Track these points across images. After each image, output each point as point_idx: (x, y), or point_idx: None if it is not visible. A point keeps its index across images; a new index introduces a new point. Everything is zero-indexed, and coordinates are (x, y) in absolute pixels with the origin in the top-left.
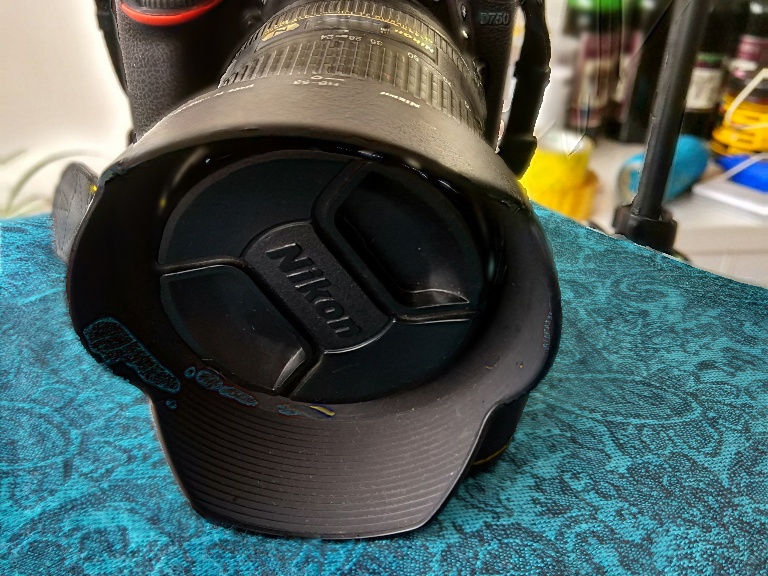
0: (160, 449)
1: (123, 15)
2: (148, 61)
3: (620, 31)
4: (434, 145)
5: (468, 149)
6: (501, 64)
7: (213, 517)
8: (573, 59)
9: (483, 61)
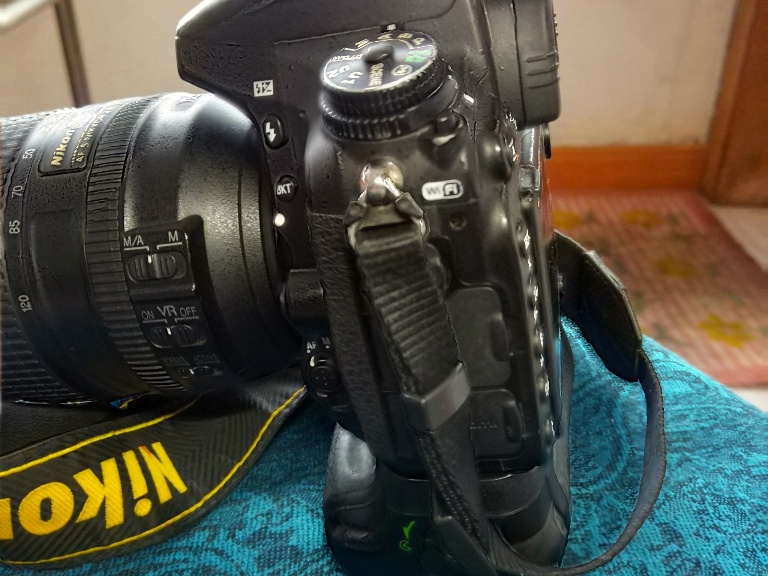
0: None
1: None
2: None
3: None
4: None
5: None
6: None
7: None
8: None
9: None
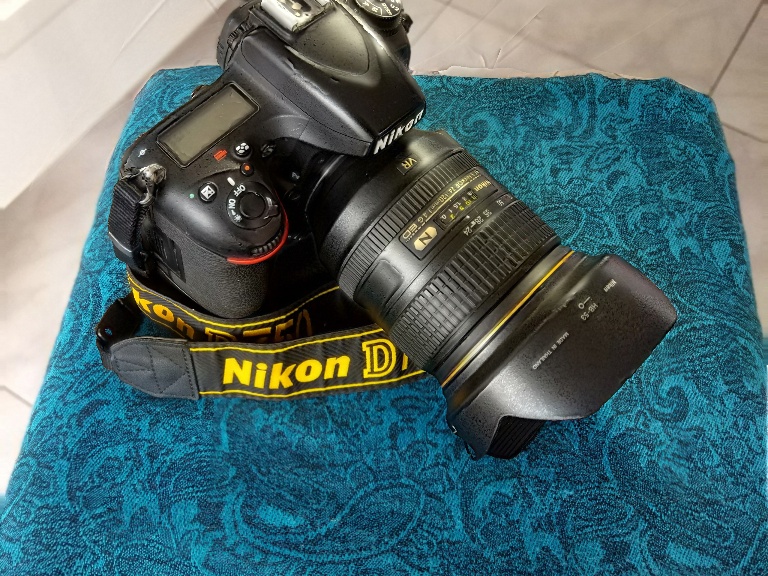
0: (446, 450)
1: None
2: (249, 272)
3: None
4: (656, 308)
5: (641, 285)
6: None
7: (515, 454)
8: None
9: None
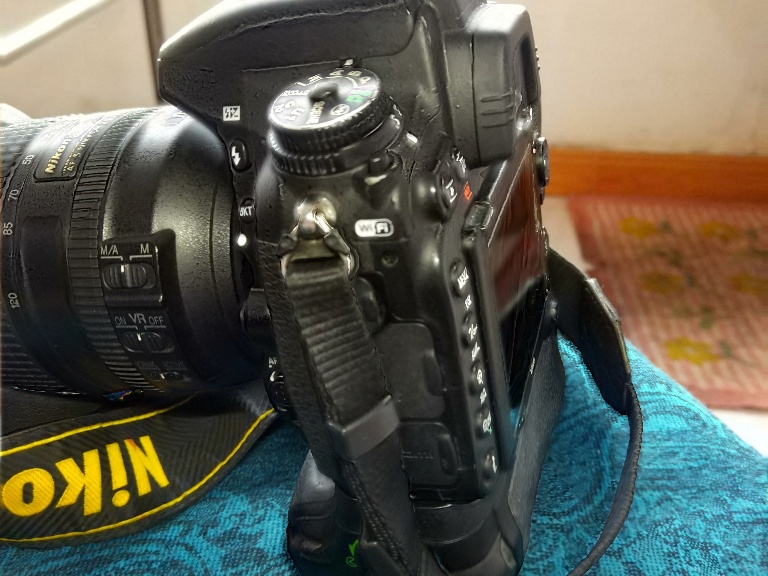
0: None
1: None
2: None
3: None
4: None
5: None
6: None
7: None
8: None
9: None
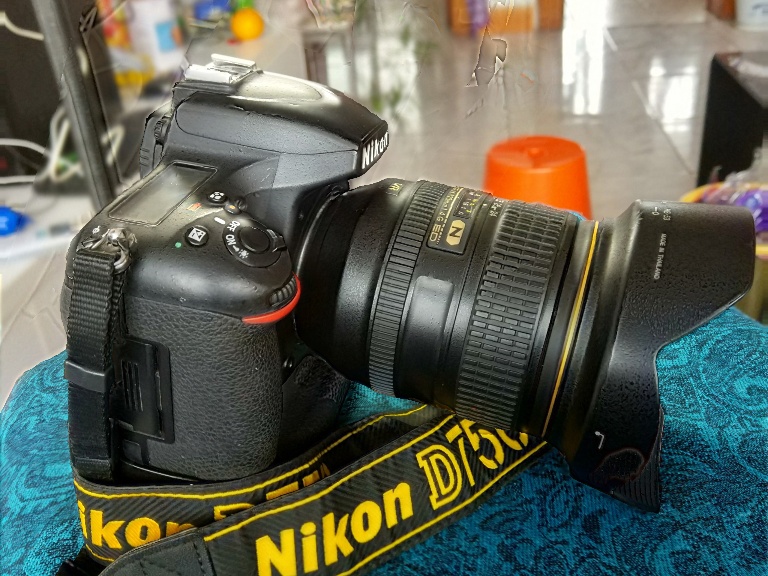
0: (579, 541)
1: (248, 328)
2: (266, 355)
3: (109, 146)
4: None
5: None
6: None
7: None
8: (61, 190)
9: None
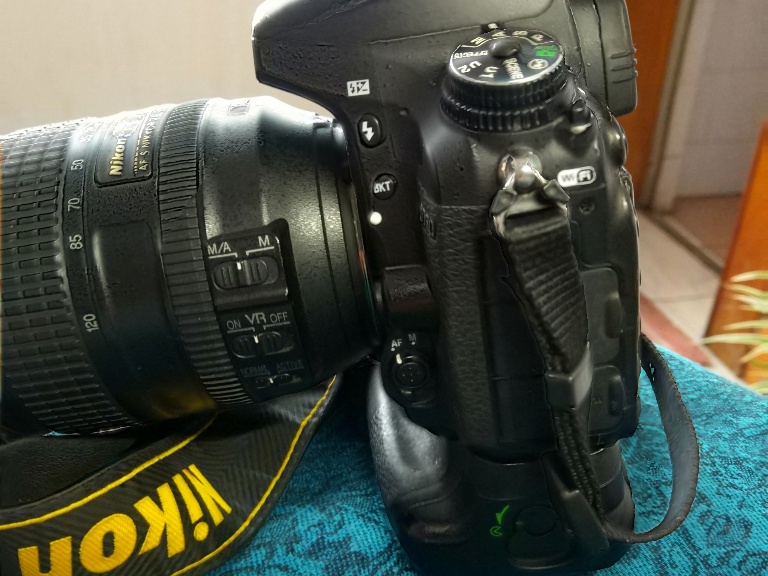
0: None
1: None
2: None
3: None
4: None
5: None
6: (440, 298)
7: None
8: None
9: (428, 278)
